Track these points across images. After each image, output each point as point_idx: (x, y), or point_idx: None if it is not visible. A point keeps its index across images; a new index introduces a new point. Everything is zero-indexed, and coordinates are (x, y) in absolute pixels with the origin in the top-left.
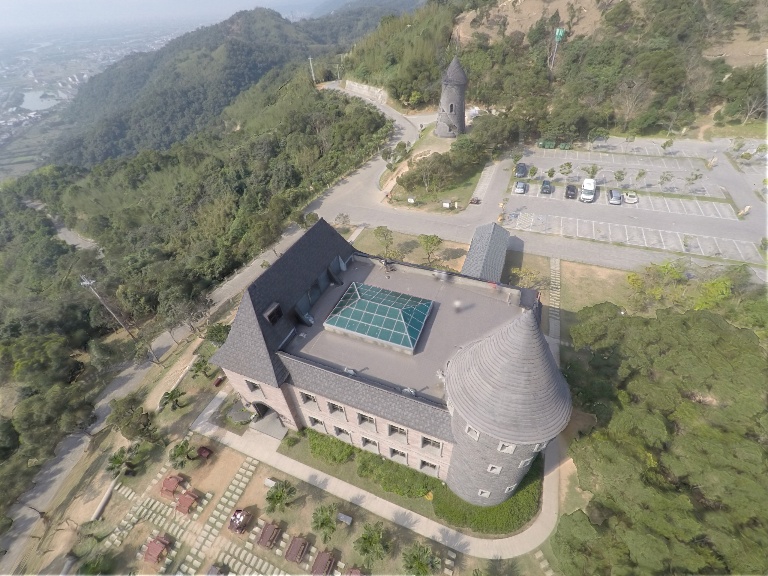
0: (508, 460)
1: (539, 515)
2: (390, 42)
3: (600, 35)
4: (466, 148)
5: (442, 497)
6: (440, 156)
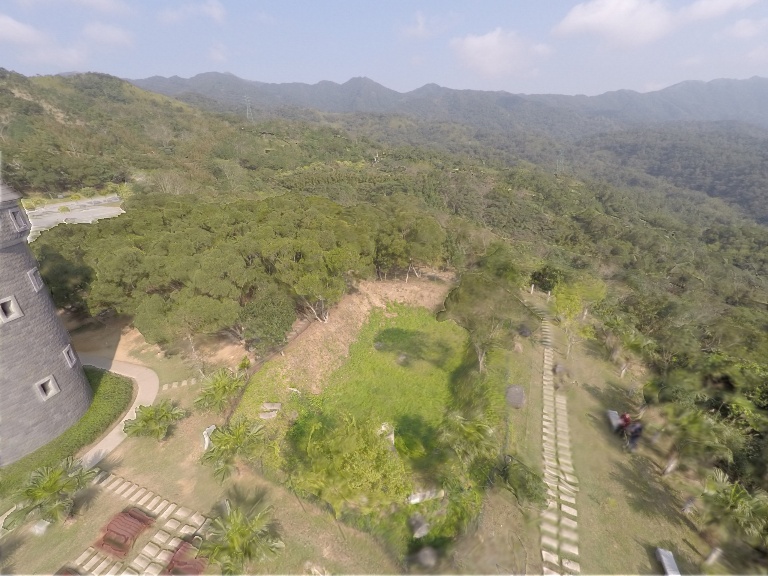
0: (7, 274)
1: (135, 380)
2: None
3: None
4: None
5: (6, 477)
6: None
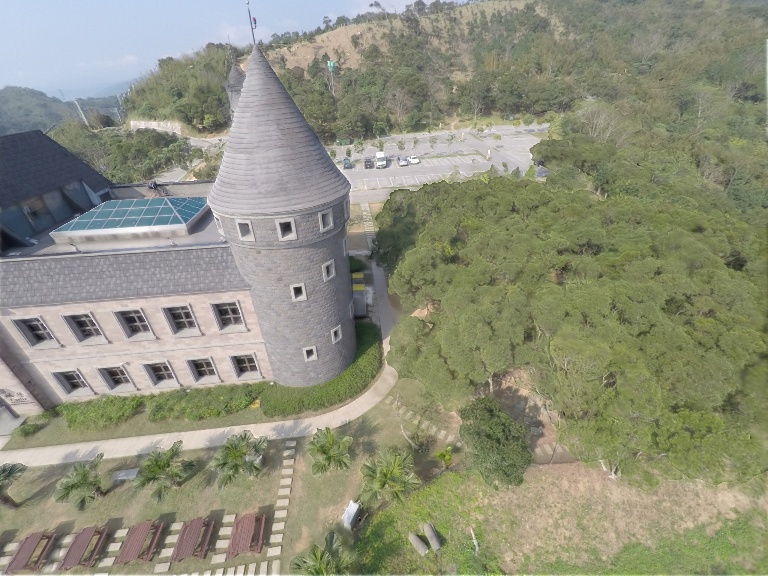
0: (304, 265)
1: (383, 370)
2: (173, 80)
3: (363, 68)
4: None
5: (271, 395)
6: None
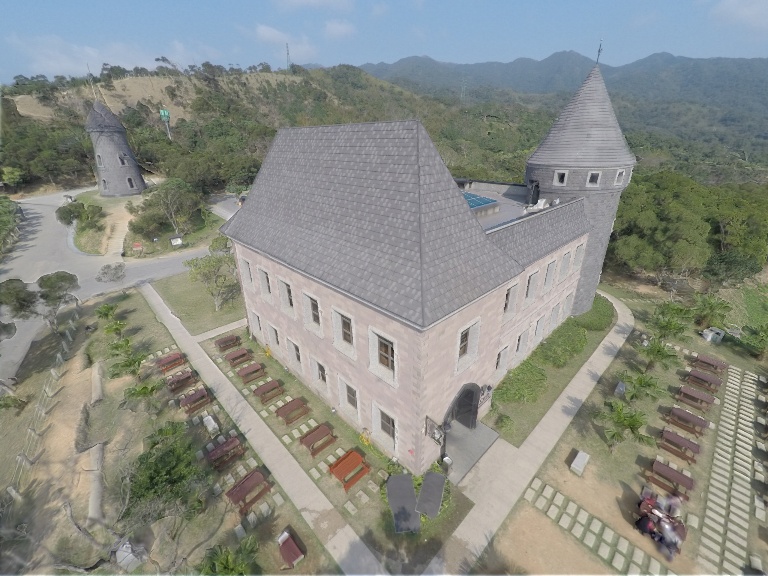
0: None
1: None
2: None
3: (198, 119)
4: (185, 188)
5: (586, 321)
6: None
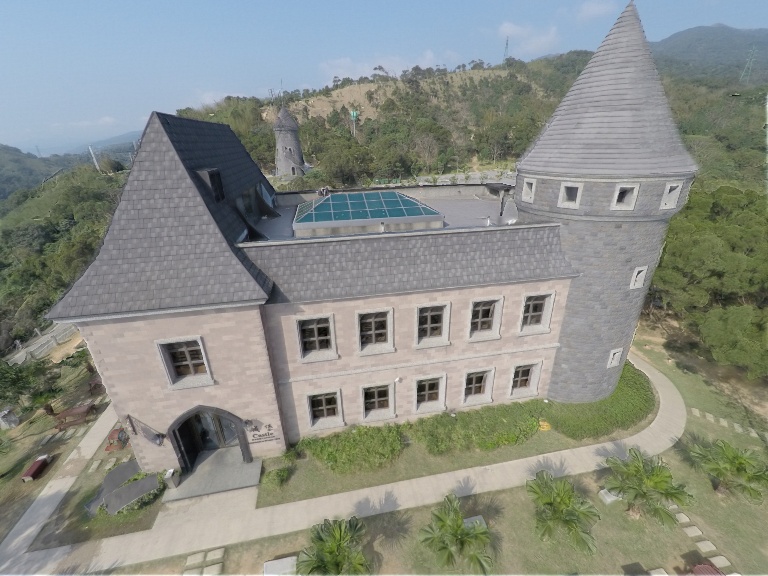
0: (656, 243)
1: (651, 381)
2: None
3: (382, 118)
4: (320, 177)
5: (560, 414)
6: (300, 178)
